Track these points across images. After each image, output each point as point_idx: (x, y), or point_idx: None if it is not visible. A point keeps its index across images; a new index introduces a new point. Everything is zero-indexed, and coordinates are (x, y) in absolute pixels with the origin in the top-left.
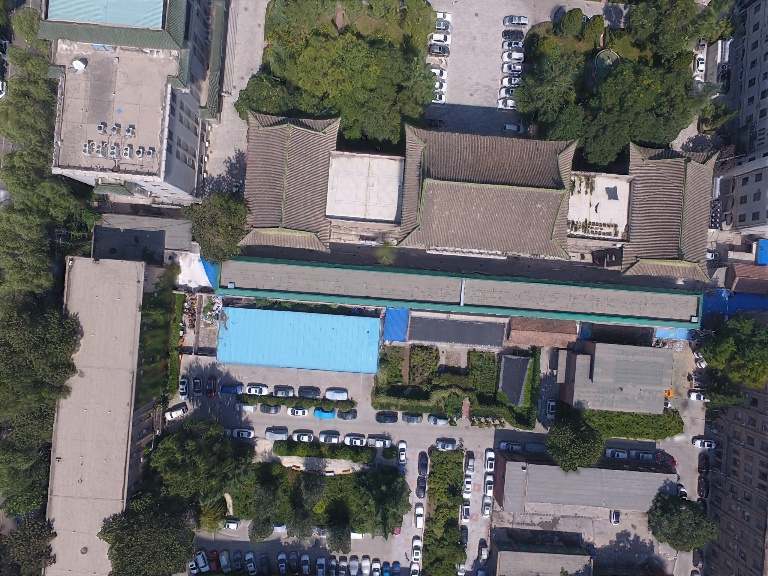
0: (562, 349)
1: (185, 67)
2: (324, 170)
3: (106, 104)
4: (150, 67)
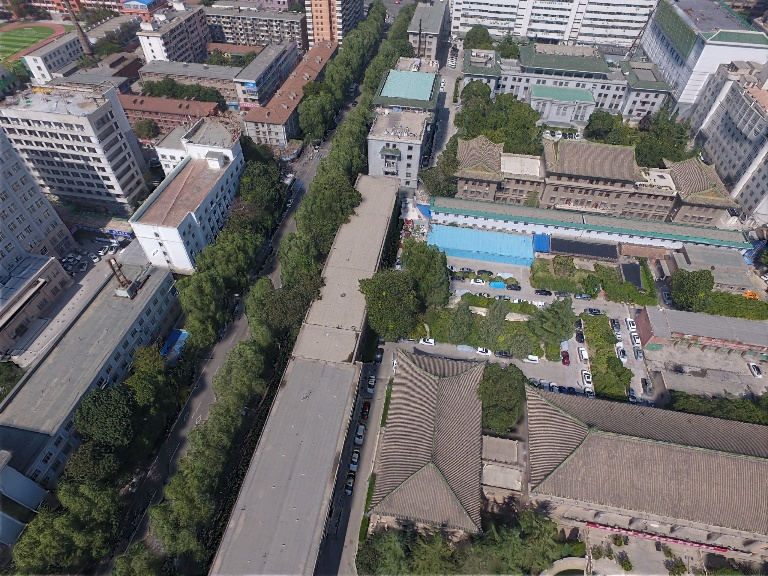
0: (661, 259)
1: (433, 117)
2: (498, 156)
3: (396, 123)
4: (417, 116)
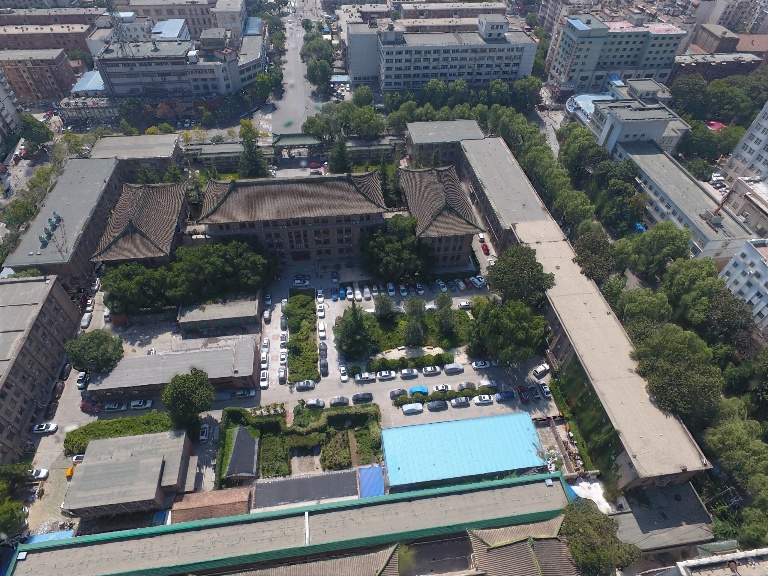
0: (190, 492)
1: None
2: None
3: None
4: None
